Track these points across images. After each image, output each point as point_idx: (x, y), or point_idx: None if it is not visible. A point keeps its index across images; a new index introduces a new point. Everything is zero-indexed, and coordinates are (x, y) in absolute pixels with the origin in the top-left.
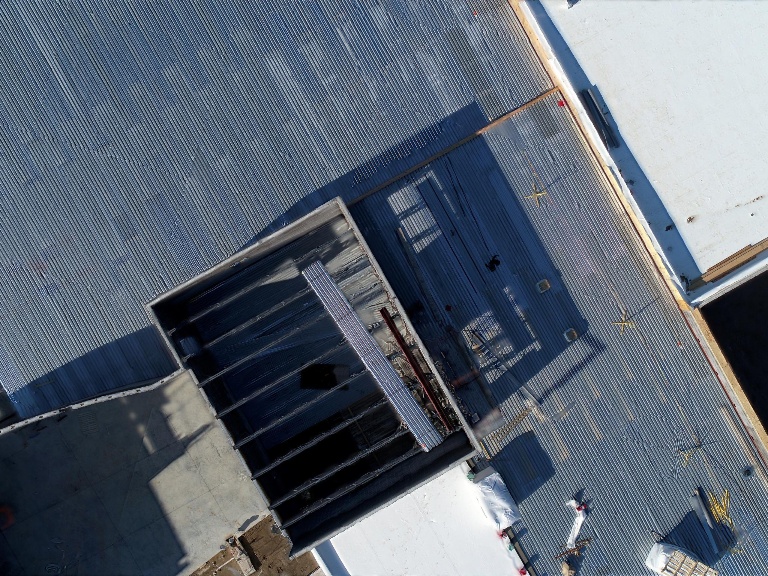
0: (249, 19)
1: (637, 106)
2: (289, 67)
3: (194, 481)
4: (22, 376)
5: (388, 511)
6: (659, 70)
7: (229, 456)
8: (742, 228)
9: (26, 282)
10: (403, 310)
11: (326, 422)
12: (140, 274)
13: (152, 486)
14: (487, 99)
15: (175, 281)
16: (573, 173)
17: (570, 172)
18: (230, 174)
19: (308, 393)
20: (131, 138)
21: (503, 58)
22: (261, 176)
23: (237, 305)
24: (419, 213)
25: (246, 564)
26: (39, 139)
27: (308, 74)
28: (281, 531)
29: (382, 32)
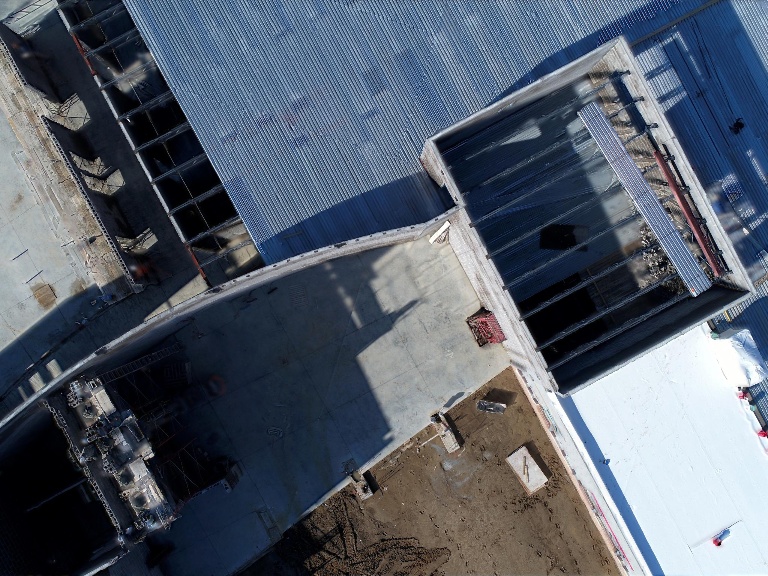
0: None
1: None
2: None
3: (401, 356)
4: (270, 227)
5: (629, 370)
6: None
7: (436, 332)
8: None
9: (275, 134)
10: (682, 150)
11: (562, 284)
12: (387, 129)
13: (359, 360)
14: None
15: (421, 136)
16: None
17: None
18: (477, 31)
19: (547, 253)
20: None
21: None
22: (508, 34)
23: (479, 164)
24: (665, 74)
25: (451, 441)
26: None
27: None
28: (547, 373)
29: None
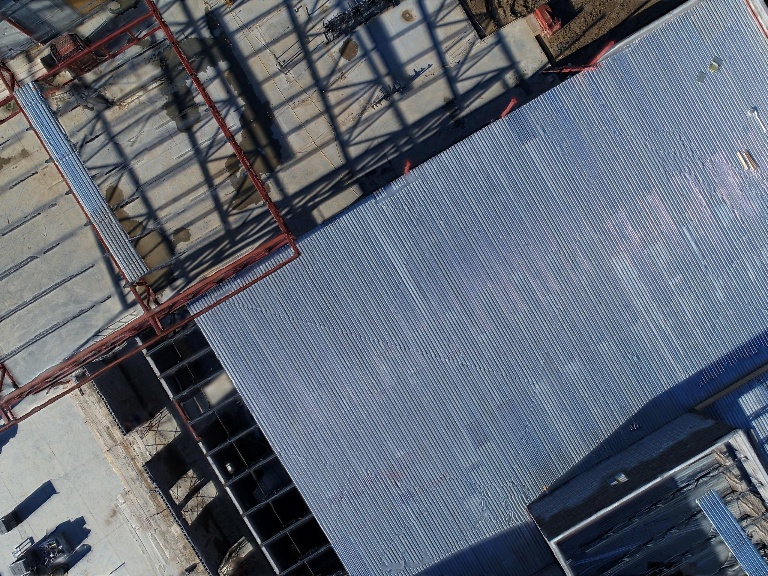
0: (596, 221)
1: None
2: (636, 268)
3: None
4: None
5: None
6: None
7: None
8: None
9: (381, 491)
10: None
11: None
12: (492, 480)
13: None
14: None
15: (527, 486)
16: None
17: None
18: (579, 378)
19: None
20: (481, 345)
21: None
22: (610, 379)
23: None
24: None
25: None
26: (391, 349)
27: (655, 275)
28: None
29: (728, 230)
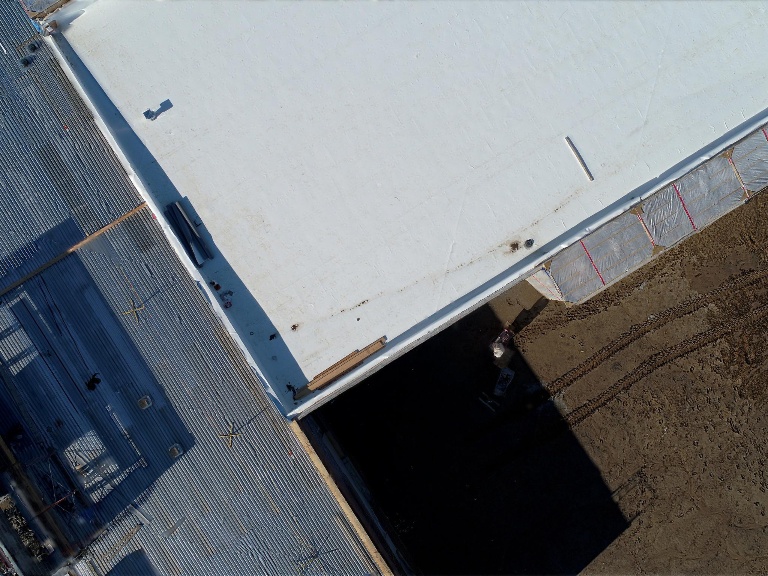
0: None
1: (231, 215)
2: None
3: None
4: None
5: None
6: (251, 178)
7: None
8: (348, 333)
9: None
10: None
11: None
12: None
13: None
14: (83, 214)
15: None
16: (172, 286)
17: (169, 285)
18: None
19: None
20: None
21: (97, 171)
22: None
23: None
24: (14, 335)
25: None
26: None
27: None
28: None
29: None
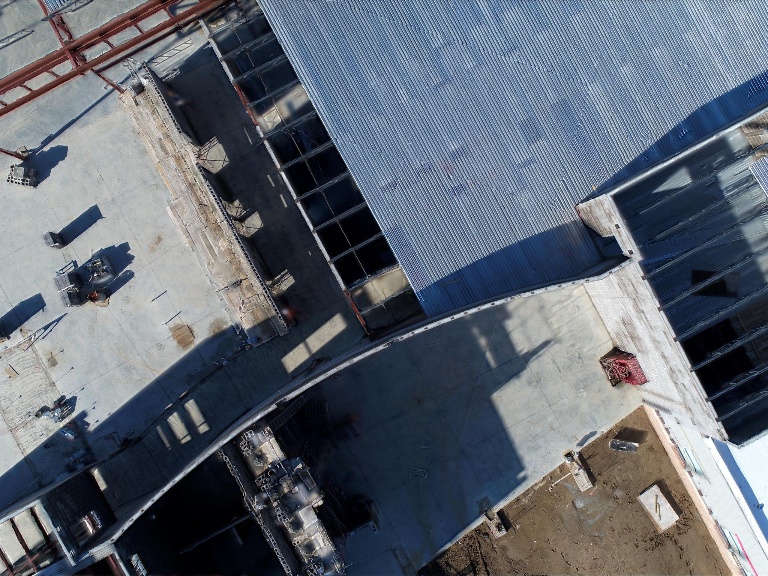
0: None
1: None
2: None
3: (535, 396)
4: (429, 275)
5: None
6: None
7: (569, 372)
8: None
9: (434, 183)
10: None
11: (711, 329)
12: (543, 178)
13: (493, 400)
14: None
15: (577, 185)
16: None
17: None
18: (631, 82)
19: (698, 299)
20: (537, 44)
21: None
22: (661, 84)
23: None
24: None
25: (583, 479)
26: (449, 43)
27: None
28: (717, 423)
29: None
